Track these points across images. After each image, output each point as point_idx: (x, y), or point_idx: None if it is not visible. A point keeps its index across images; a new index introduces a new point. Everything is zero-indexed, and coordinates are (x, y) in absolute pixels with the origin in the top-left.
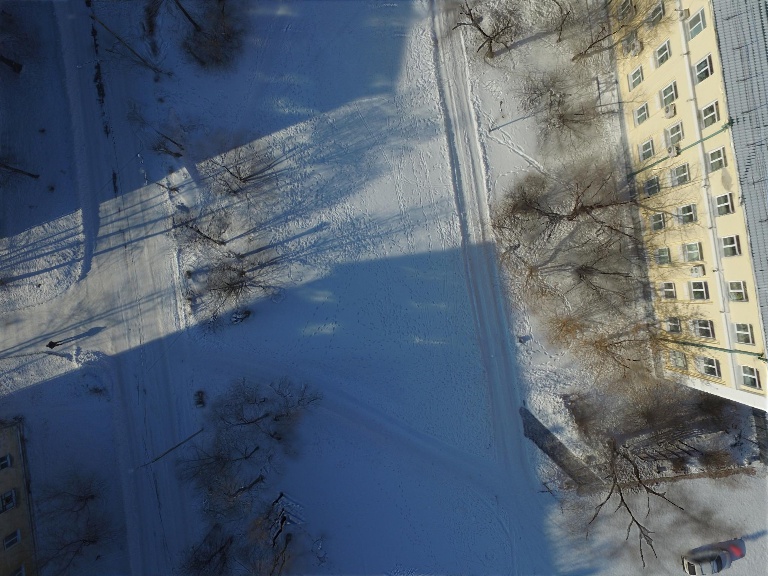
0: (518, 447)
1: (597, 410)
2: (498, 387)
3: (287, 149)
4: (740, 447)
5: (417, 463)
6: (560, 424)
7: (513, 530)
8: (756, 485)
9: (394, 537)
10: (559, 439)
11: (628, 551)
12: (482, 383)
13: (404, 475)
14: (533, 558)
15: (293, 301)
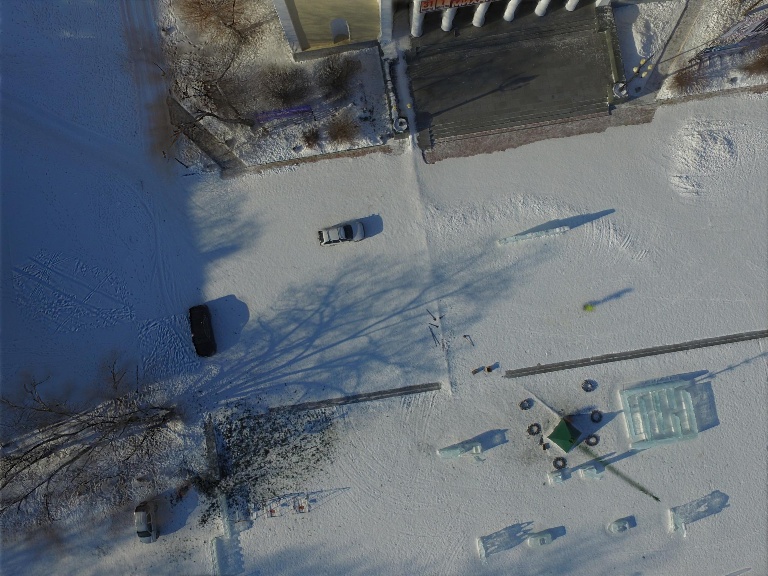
0: (164, 134)
1: (238, 95)
2: (145, 78)
3: None
4: (372, 123)
5: (65, 152)
6: (201, 108)
7: (157, 213)
8: (392, 162)
9: (39, 223)
10: (203, 124)
11: (269, 230)
12: (128, 73)
13: (51, 163)
14: (177, 240)
15: None
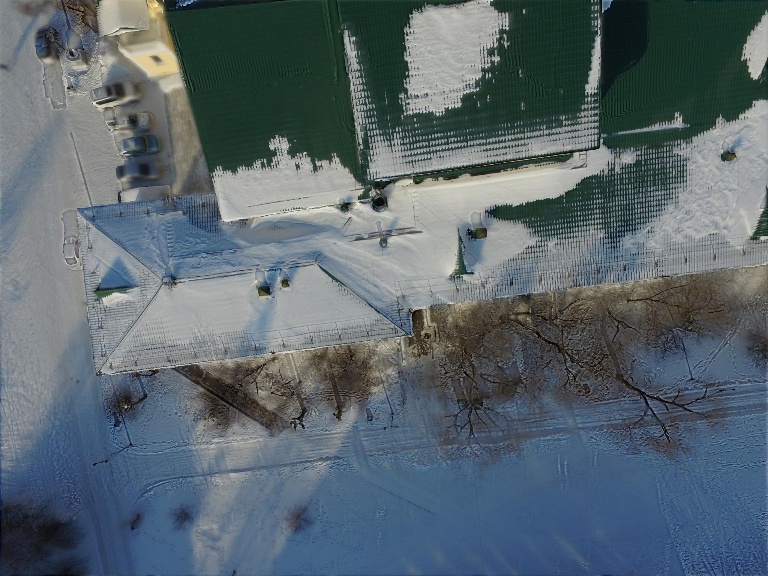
0: None
1: None
2: None
3: (703, 569)
4: None
5: None
6: None
7: None
8: None
9: None
10: None
11: None
12: None
13: None
14: None
15: None
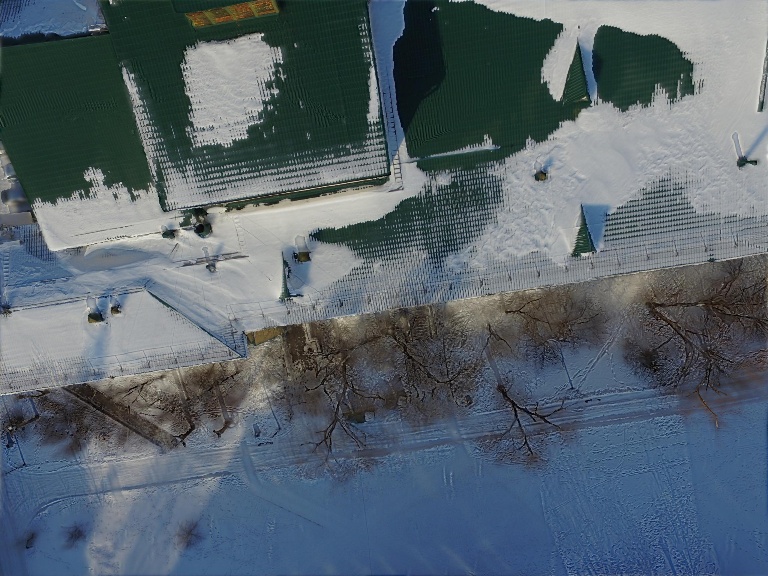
0: None
1: None
2: None
3: None
4: None
5: None
6: None
7: None
8: None
9: None
10: None
11: None
12: None
13: None
14: None
15: (734, 572)
